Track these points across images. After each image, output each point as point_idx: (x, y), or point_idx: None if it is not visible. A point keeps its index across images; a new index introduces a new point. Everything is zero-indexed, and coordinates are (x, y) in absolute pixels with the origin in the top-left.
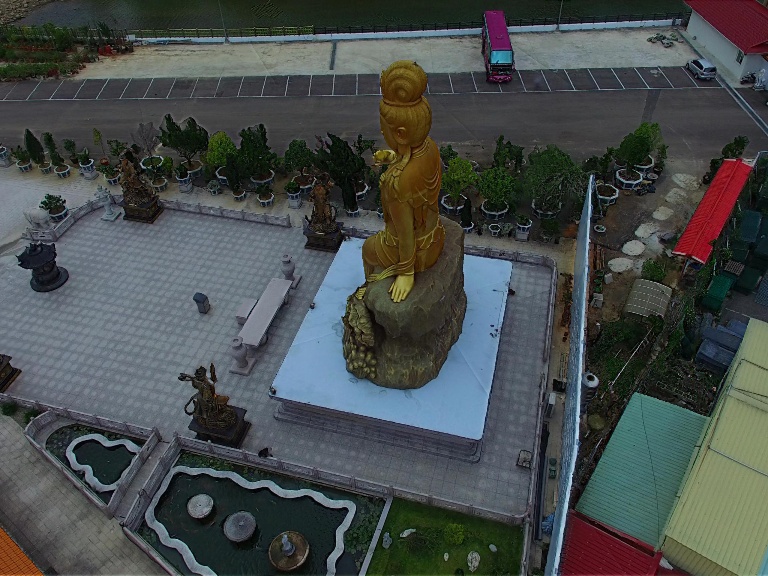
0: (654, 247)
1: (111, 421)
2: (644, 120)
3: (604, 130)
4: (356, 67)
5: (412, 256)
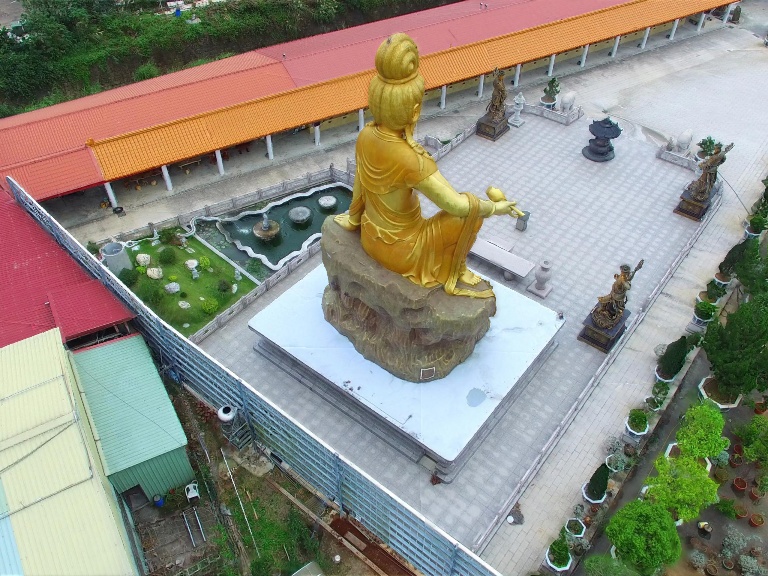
0: None
1: None
2: None
3: None
4: None
5: None
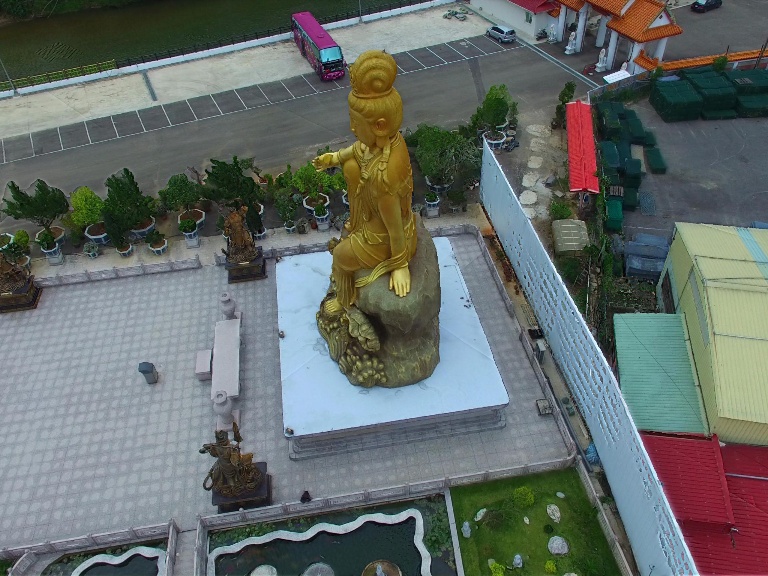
0: (544, 192)
1: (112, 534)
2: (478, 87)
3: (450, 102)
4: (181, 93)
5: (406, 247)
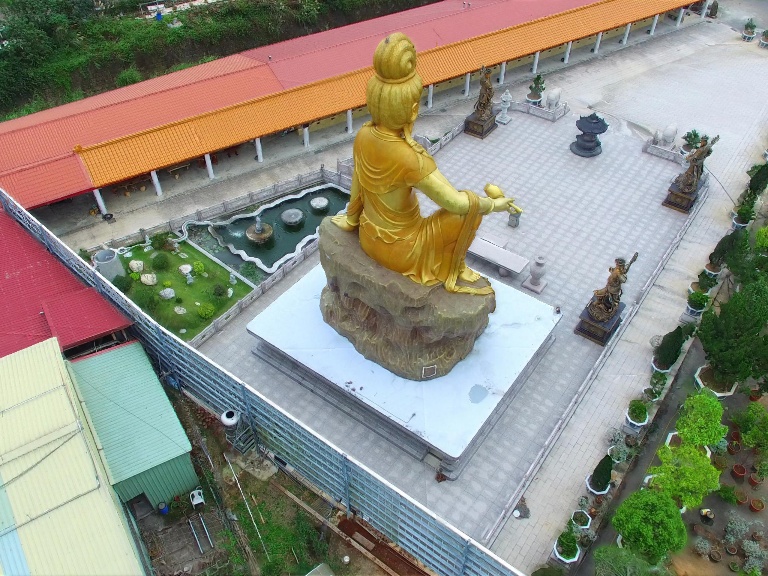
0: None
1: None
2: None
3: None
4: None
5: None
